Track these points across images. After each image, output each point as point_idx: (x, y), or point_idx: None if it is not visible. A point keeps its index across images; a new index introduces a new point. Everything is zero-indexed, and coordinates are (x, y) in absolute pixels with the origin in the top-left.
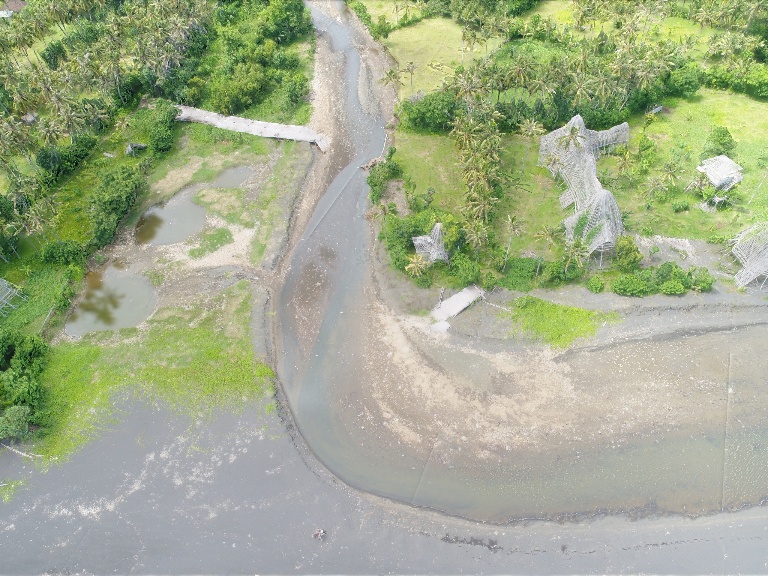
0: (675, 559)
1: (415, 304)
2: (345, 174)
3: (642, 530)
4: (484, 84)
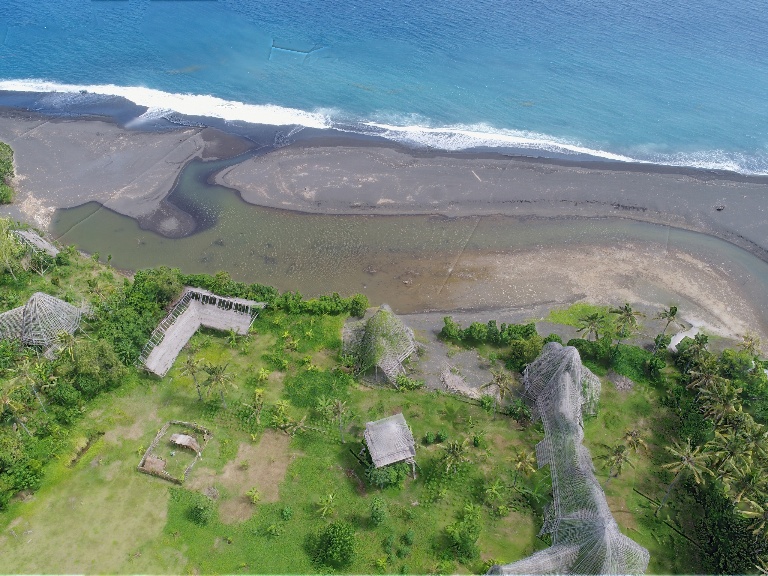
0: (518, 194)
1: (729, 340)
2: None
3: (531, 210)
4: None
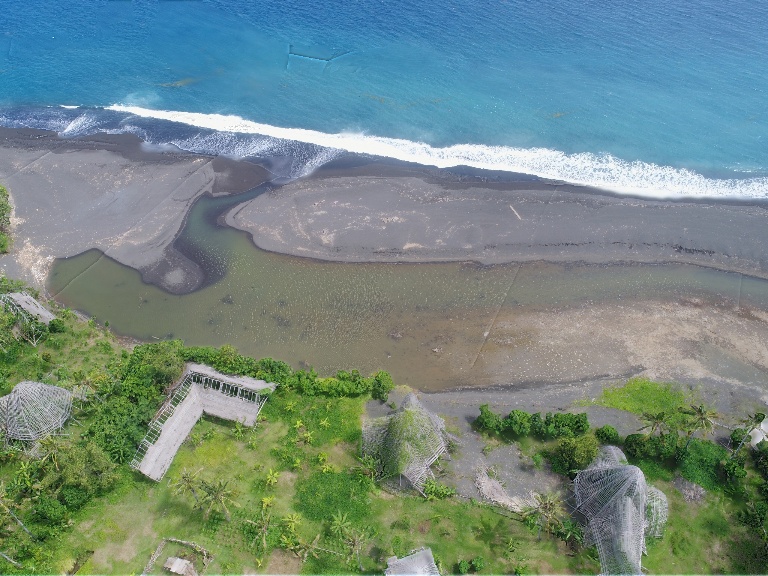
0: (564, 235)
1: None
2: None
3: (578, 254)
4: None
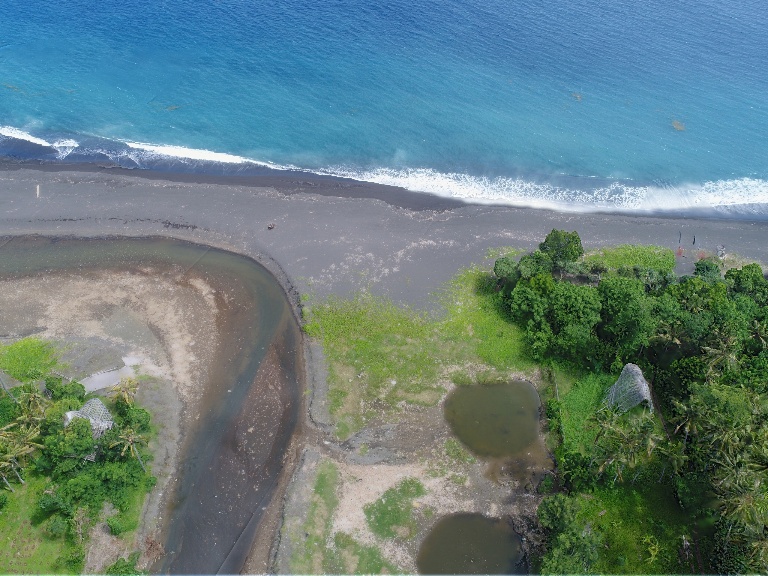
0: (65, 212)
1: (147, 382)
2: None
3: (72, 229)
4: None
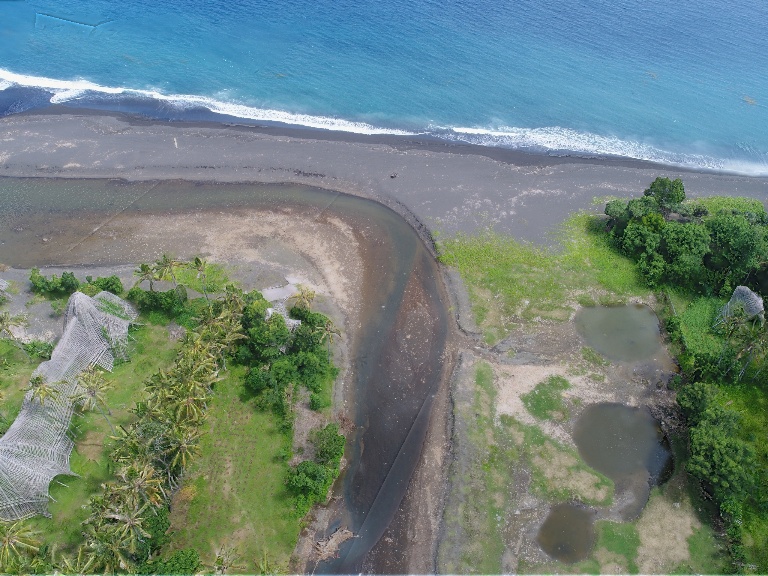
0: (205, 160)
1: None
2: (380, 521)
3: (212, 175)
4: None
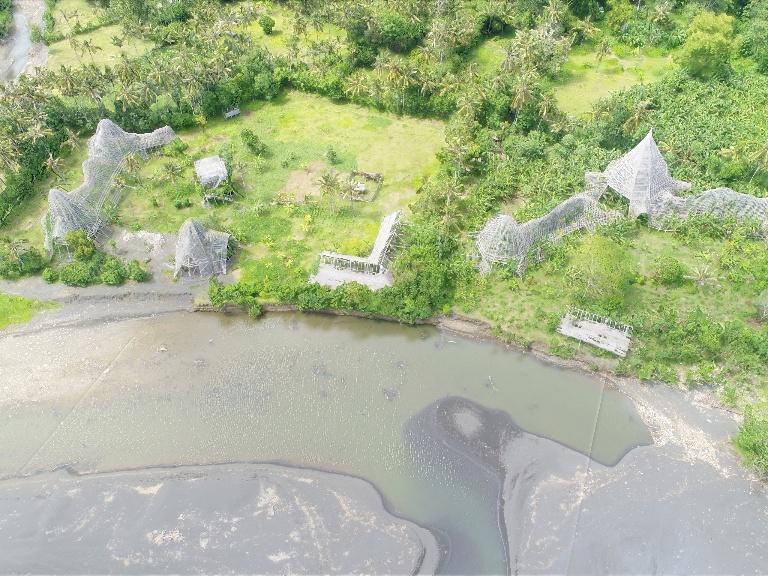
0: None
1: None
2: None
3: None
4: (26, 91)
